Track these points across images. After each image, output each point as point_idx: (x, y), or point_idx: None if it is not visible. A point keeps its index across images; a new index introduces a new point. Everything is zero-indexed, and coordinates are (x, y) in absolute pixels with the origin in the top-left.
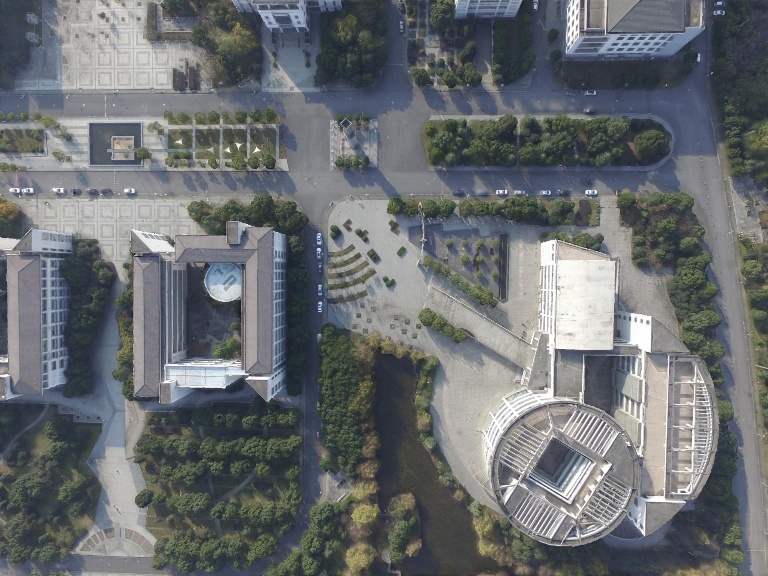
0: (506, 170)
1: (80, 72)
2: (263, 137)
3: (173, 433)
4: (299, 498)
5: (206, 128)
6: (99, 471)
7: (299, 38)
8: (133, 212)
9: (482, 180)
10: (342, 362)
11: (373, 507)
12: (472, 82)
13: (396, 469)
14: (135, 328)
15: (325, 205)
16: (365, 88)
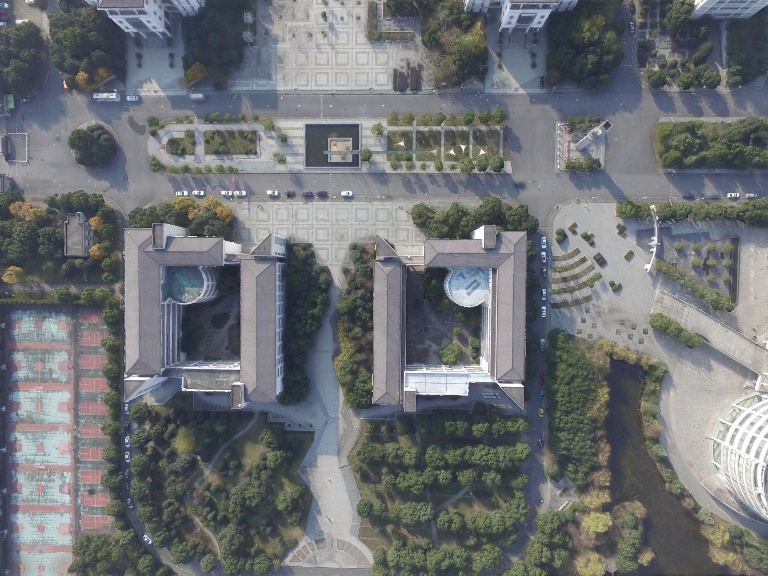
0: (737, 173)
1: (296, 72)
2: (486, 139)
3: (390, 441)
4: (527, 507)
5: (427, 130)
6: (310, 480)
7: (526, 38)
8: (349, 215)
9: (712, 183)
10: (581, 368)
11: (607, 516)
12: (712, 84)
13: (619, 477)
14: (375, 334)
15: (550, 208)
16: (592, 89)
